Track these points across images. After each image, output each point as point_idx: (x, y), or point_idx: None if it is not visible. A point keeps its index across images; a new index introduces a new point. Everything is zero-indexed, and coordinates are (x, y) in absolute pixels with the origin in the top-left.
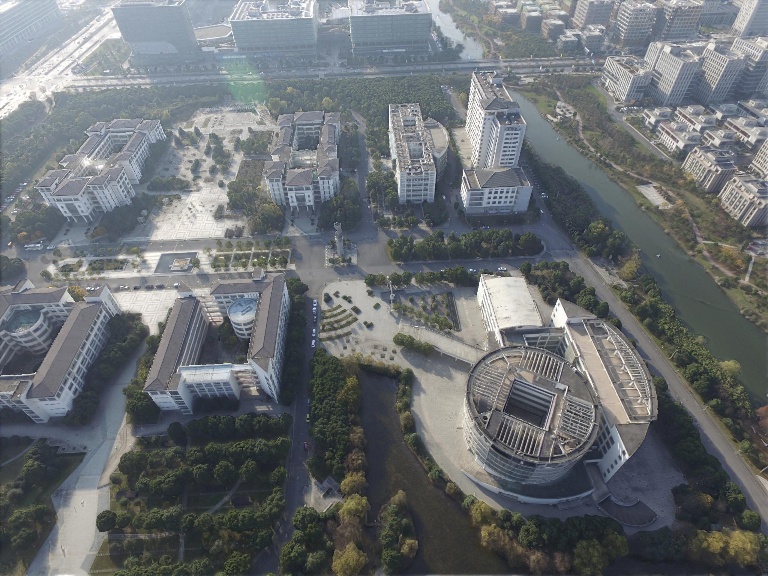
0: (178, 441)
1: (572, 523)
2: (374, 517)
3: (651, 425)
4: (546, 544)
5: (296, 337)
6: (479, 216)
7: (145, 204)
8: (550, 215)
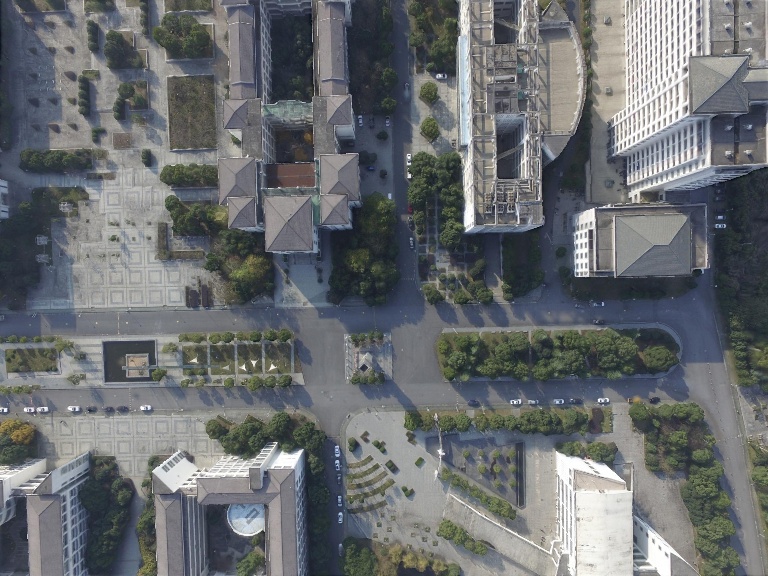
0: None
1: None
2: None
3: None
4: None
5: (319, 533)
6: None
7: (34, 216)
8: (713, 279)
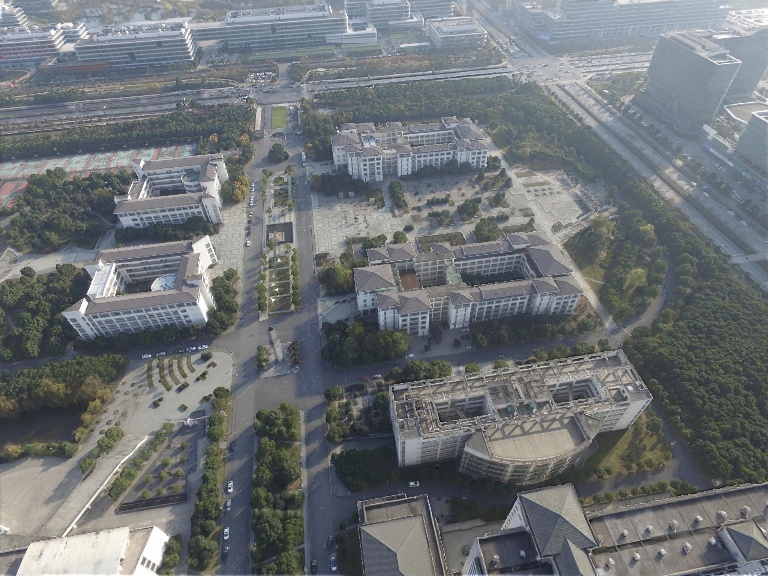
0: None
1: None
2: None
3: None
4: None
5: (140, 335)
6: None
7: (365, 190)
8: None
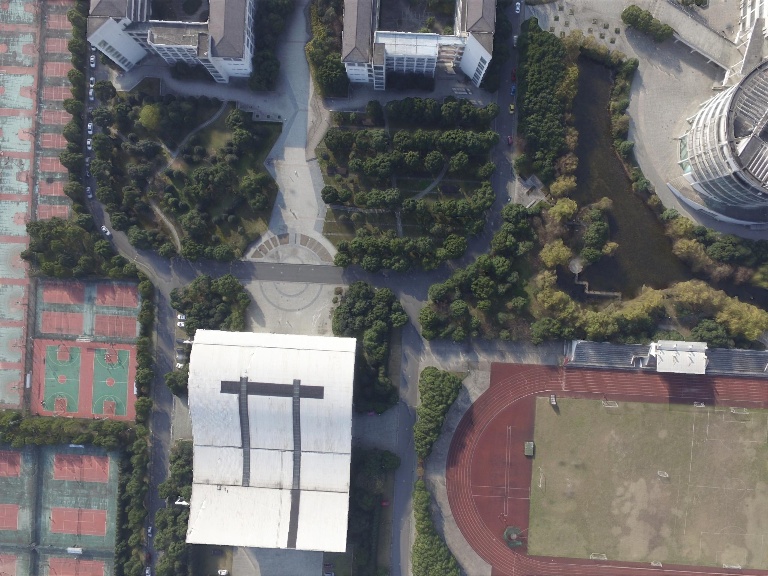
0: (376, 121)
1: (766, 246)
2: (573, 217)
3: None
4: (733, 259)
5: None
6: None
7: None
8: None
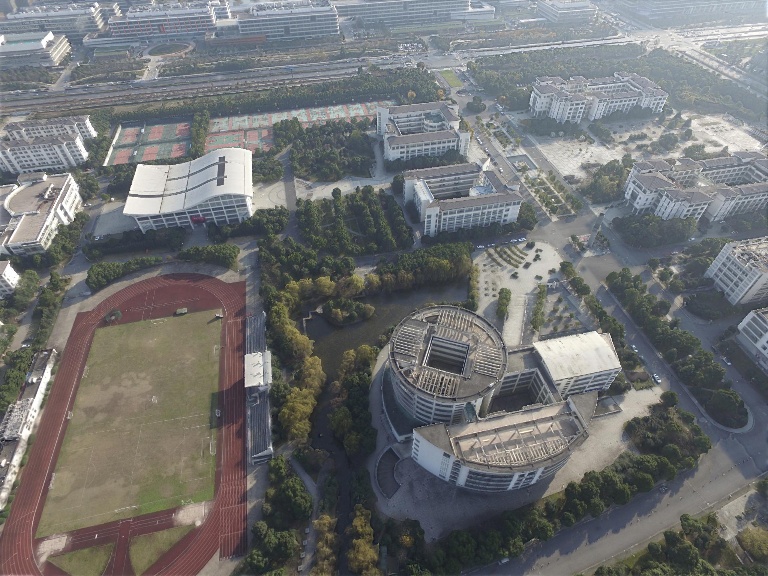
0: (386, 205)
1: None
2: None
3: (489, 518)
4: None
5: (476, 230)
6: (745, 353)
7: (571, 131)
8: None
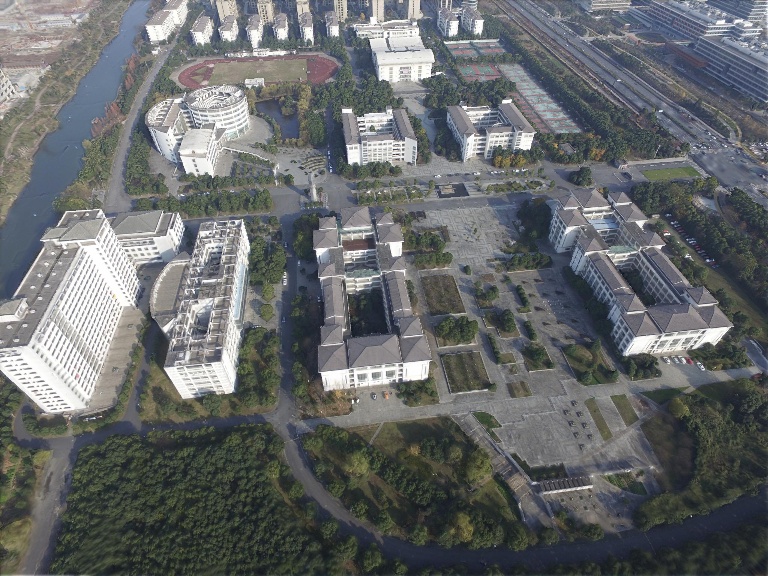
0: None
1: None
2: (296, 112)
3: None
4: None
5: None
6: None
7: None
8: None
